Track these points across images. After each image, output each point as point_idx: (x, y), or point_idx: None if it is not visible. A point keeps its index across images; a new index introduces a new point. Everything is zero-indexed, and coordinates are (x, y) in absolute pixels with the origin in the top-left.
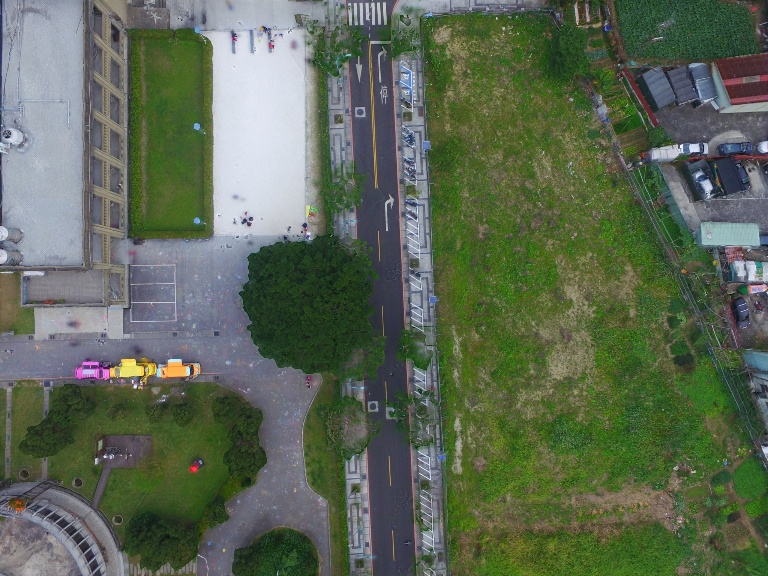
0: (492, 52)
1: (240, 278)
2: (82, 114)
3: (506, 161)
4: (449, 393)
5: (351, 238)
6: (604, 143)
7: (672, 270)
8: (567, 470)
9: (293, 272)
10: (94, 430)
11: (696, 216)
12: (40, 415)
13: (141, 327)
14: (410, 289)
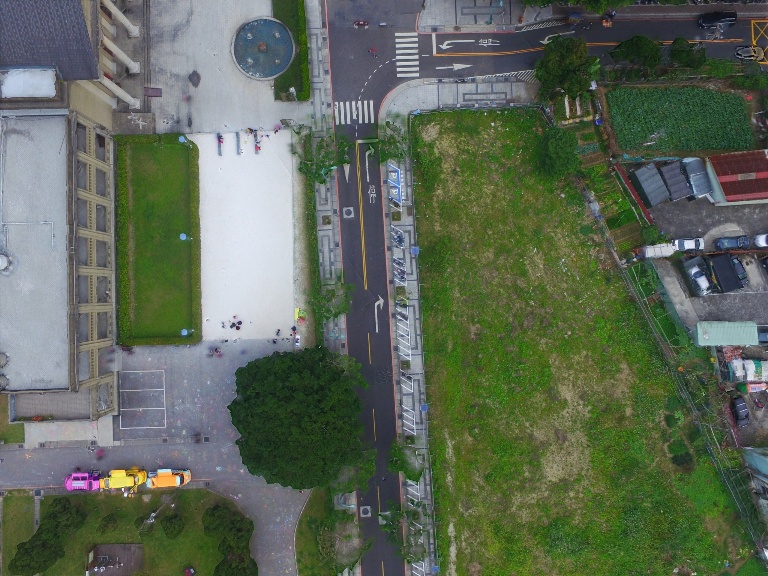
0: (481, 149)
1: (229, 383)
2: (66, 236)
3: (497, 259)
4: (442, 497)
5: (339, 354)
6: (597, 239)
7: (669, 368)
8: (564, 575)
9: (281, 390)
10: (85, 539)
11: (693, 311)
12: (31, 524)
13: (131, 434)
14: (401, 391)
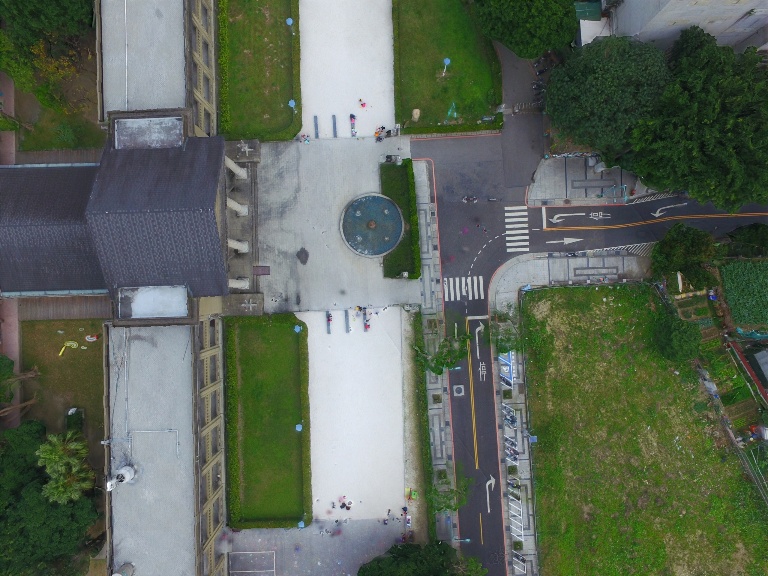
0: (593, 325)
1: (340, 564)
2: None
3: (610, 438)
4: None
5: None
6: (712, 416)
7: None
8: None
9: None
10: None
11: None
12: None
13: None
14: (514, 572)
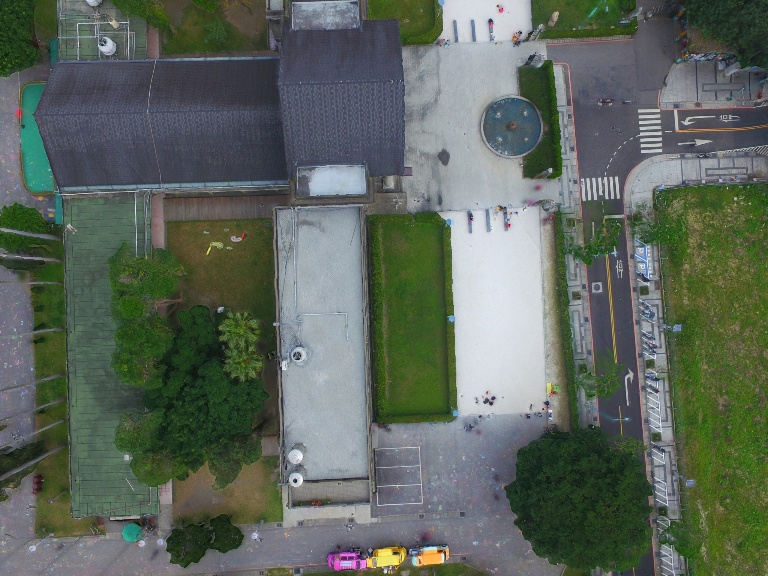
0: (725, 223)
1: (484, 458)
2: None
3: (743, 332)
4: (697, 568)
5: None
6: None
7: None
8: None
9: (570, 474)
10: None
11: None
12: None
13: (388, 510)
14: (653, 463)
